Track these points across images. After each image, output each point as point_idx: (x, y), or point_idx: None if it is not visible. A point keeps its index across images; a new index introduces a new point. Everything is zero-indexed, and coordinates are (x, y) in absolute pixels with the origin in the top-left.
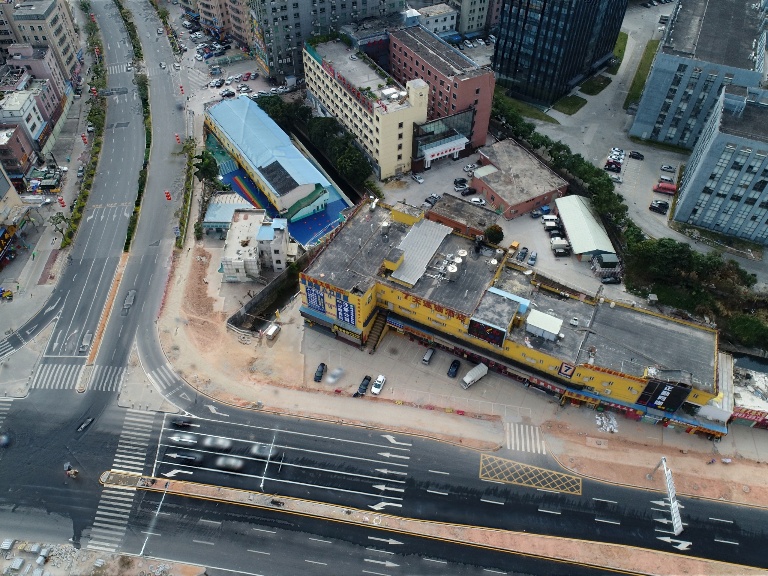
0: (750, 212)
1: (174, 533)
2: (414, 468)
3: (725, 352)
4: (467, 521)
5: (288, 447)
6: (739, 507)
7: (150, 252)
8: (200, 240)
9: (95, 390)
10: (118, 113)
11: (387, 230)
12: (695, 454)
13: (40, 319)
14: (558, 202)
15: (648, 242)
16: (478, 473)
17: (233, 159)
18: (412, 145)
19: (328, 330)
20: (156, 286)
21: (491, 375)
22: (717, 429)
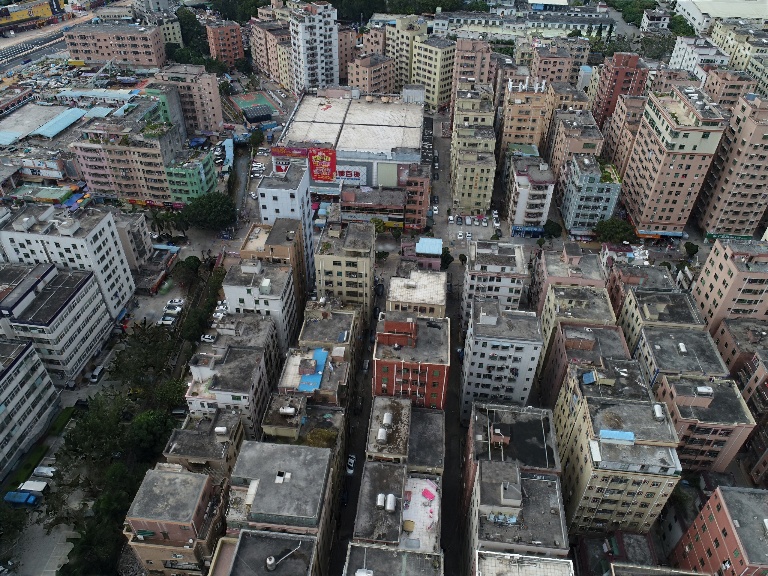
0: None
1: (3, 68)
2: (30, 43)
3: None
4: None
5: None
6: None
7: None
8: None
9: None
10: None
11: None
12: None
13: None
14: None
15: None
16: None
17: None
18: None
19: None
20: None
21: None
22: None
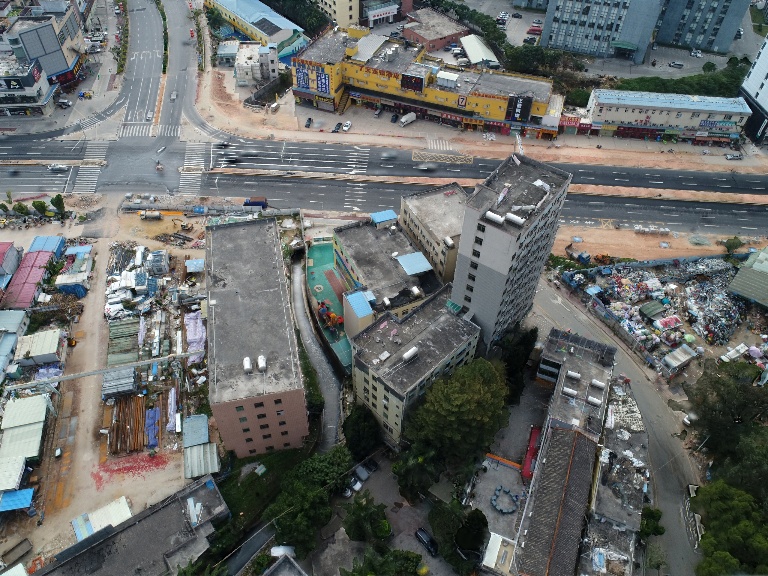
0: (584, 32)
1: (230, 188)
2: (372, 158)
3: (559, 94)
4: (405, 175)
5: (293, 153)
6: (563, 164)
7: (181, 74)
8: (215, 67)
9: (163, 135)
10: (135, 3)
11: (346, 40)
12: (541, 146)
13: (114, 107)
14: (462, 39)
15: (517, 47)
16: (411, 158)
17: (229, 26)
18: (359, 8)
19: (311, 105)
20: (190, 89)
21: (418, 121)
22: (552, 129)
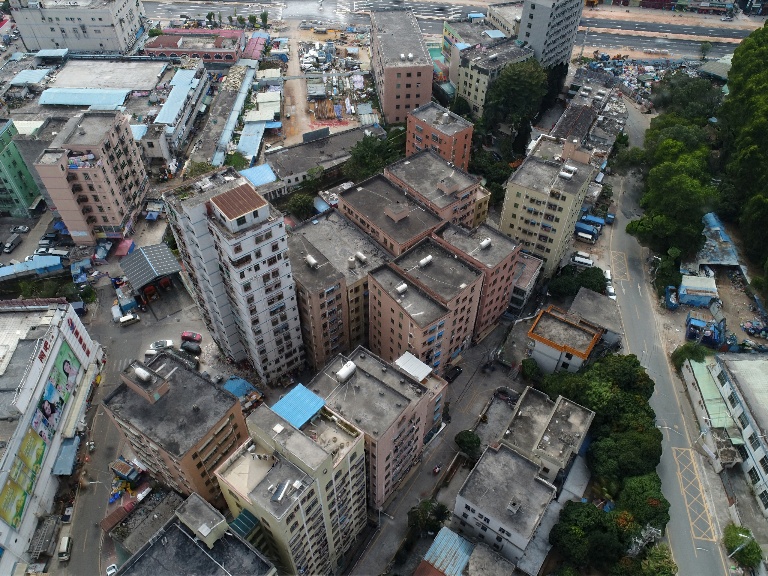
0: None
1: None
2: None
3: None
4: None
5: (410, 6)
6: None
7: None
8: None
9: None
10: None
11: None
12: None
13: None
14: None
15: None
16: None
17: None
18: None
19: None
20: None
21: None
22: None
